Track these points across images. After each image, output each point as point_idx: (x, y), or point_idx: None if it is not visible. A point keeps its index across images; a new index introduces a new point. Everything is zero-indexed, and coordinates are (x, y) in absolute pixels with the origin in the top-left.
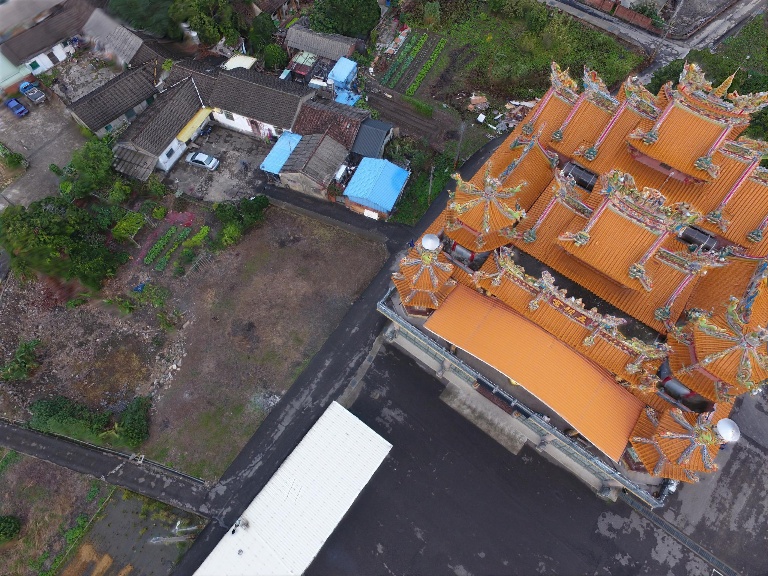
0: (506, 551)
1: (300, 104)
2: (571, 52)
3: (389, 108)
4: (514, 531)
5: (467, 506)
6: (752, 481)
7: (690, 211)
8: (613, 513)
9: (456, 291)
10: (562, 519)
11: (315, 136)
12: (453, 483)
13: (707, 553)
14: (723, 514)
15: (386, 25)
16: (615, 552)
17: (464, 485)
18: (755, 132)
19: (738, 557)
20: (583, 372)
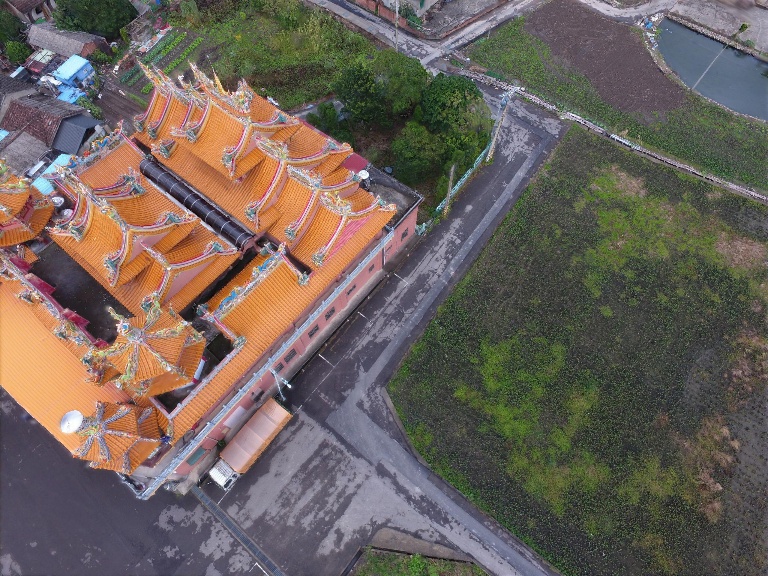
0: (58, 541)
1: (8, 101)
2: (320, 52)
3: (119, 106)
4: (74, 522)
5: (38, 497)
6: (326, 477)
7: (103, 207)
8: (179, 506)
9: (2, 285)
10: (126, 511)
11: (15, 132)
12: (33, 474)
13: (256, 547)
14: (285, 509)
15: (138, 23)
16: (165, 544)
17: (43, 476)
18: (419, 132)
19: (284, 551)
20: (67, 365)
